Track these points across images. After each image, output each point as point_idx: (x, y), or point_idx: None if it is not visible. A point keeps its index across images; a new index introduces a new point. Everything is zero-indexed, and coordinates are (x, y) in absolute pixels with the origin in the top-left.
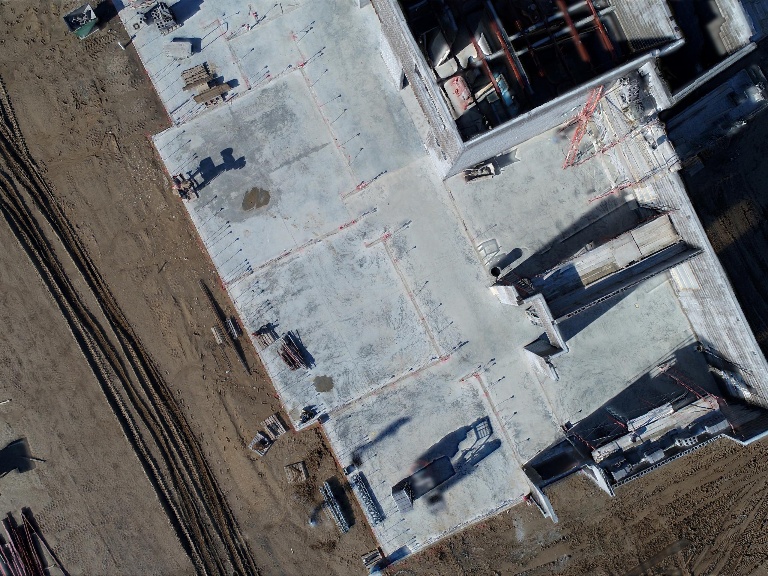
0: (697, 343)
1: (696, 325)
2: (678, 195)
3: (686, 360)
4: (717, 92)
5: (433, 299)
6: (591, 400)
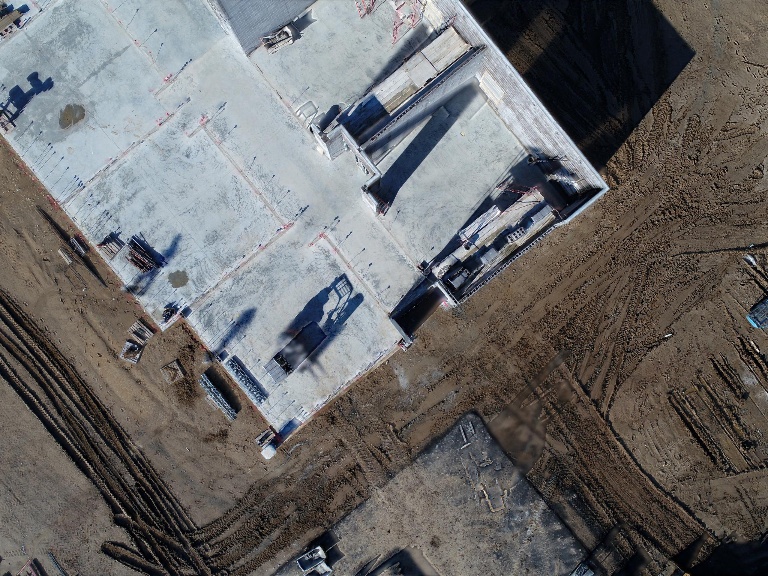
0: (529, 156)
1: (521, 137)
2: None
3: (523, 175)
4: None
5: (265, 173)
6: (440, 235)
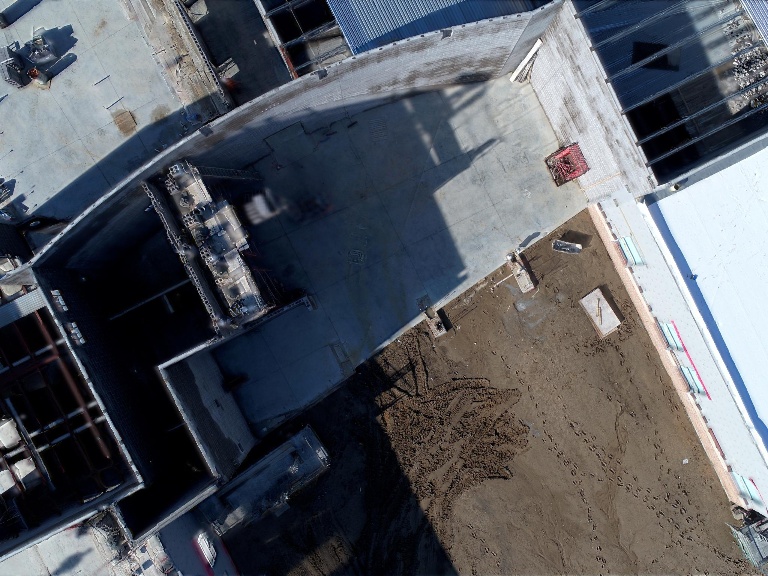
0: None
1: None
2: None
3: None
4: (279, 451)
5: None
6: None
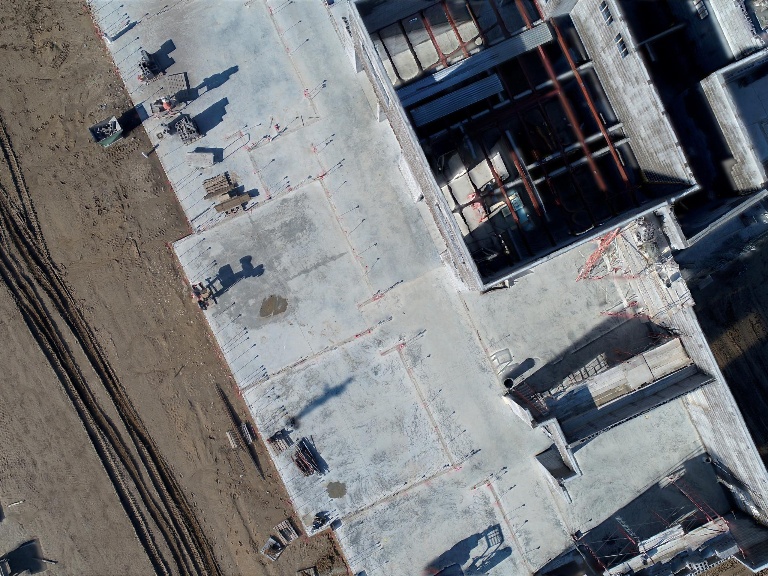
0: (706, 454)
1: (705, 438)
2: (690, 324)
3: (695, 471)
4: None
5: (446, 407)
6: (601, 509)
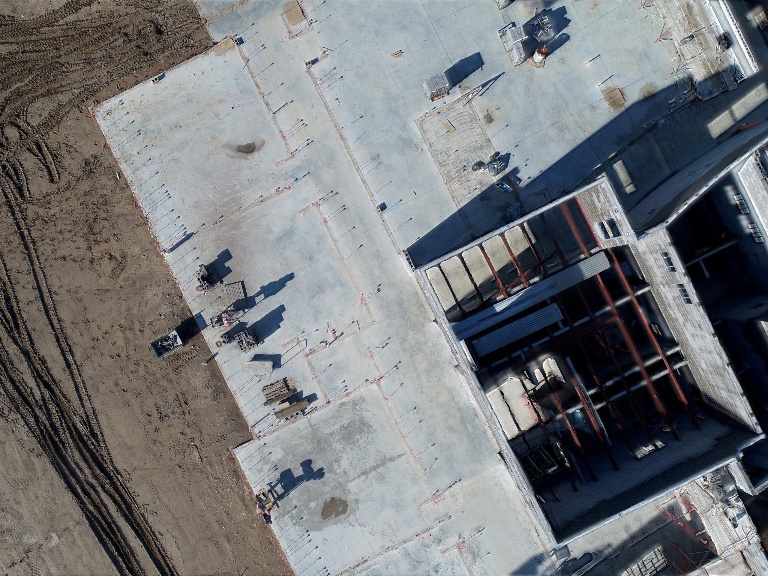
0: None
1: None
2: (753, 548)
3: None
4: None
5: None
6: None
